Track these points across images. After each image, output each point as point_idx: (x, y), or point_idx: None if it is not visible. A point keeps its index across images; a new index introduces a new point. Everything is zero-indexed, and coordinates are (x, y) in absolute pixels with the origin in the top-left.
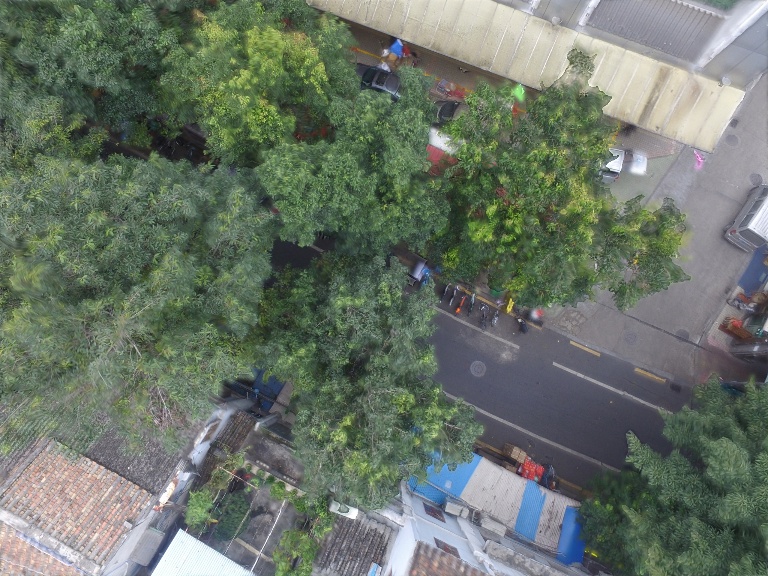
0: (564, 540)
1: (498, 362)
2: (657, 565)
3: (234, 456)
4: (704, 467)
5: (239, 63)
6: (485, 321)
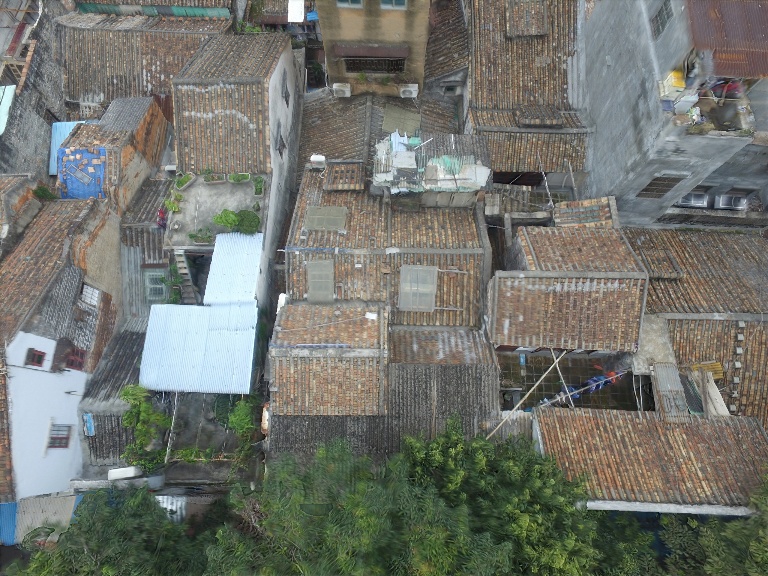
0: None
1: None
2: None
3: None
4: None
5: None
6: None
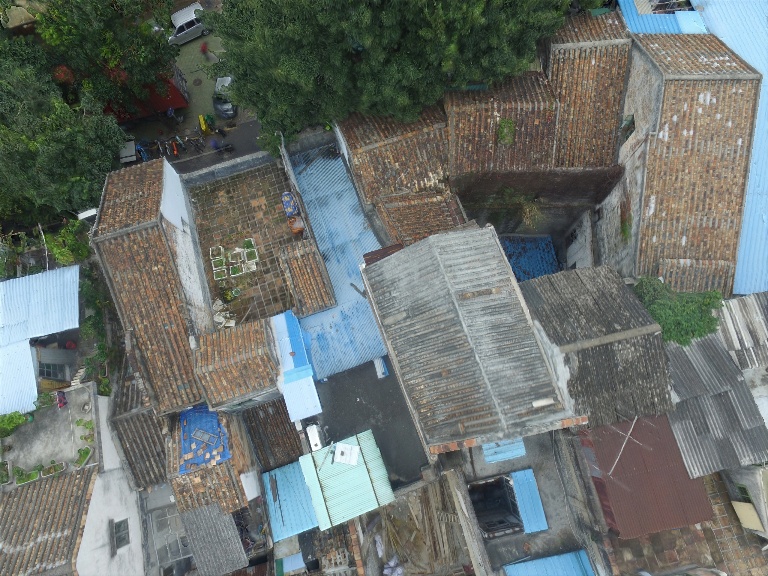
0: None
1: None
2: None
3: None
4: None
5: None
6: (198, 147)
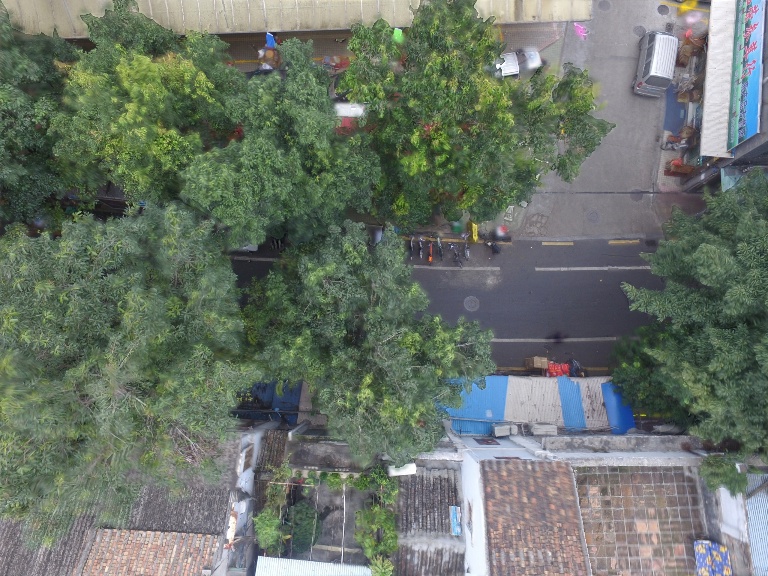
0: (612, 415)
1: (487, 290)
2: (695, 384)
3: (280, 469)
4: (698, 284)
5: (121, 100)
6: (459, 258)
